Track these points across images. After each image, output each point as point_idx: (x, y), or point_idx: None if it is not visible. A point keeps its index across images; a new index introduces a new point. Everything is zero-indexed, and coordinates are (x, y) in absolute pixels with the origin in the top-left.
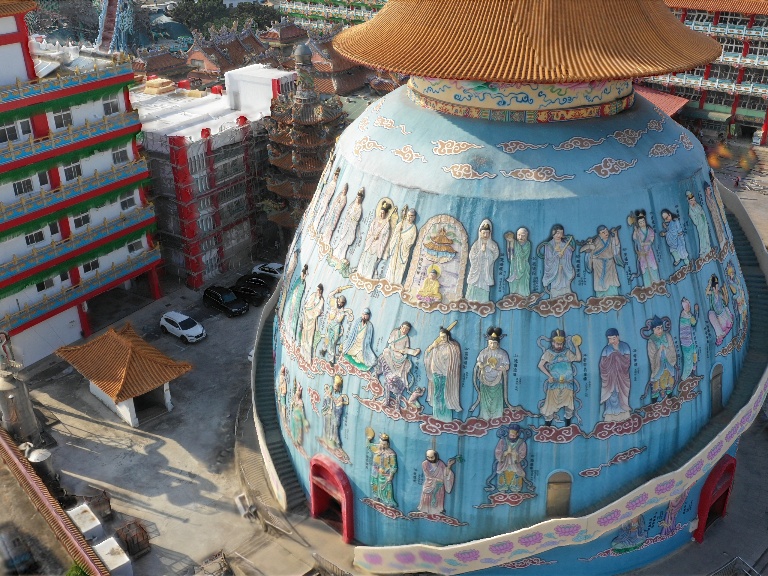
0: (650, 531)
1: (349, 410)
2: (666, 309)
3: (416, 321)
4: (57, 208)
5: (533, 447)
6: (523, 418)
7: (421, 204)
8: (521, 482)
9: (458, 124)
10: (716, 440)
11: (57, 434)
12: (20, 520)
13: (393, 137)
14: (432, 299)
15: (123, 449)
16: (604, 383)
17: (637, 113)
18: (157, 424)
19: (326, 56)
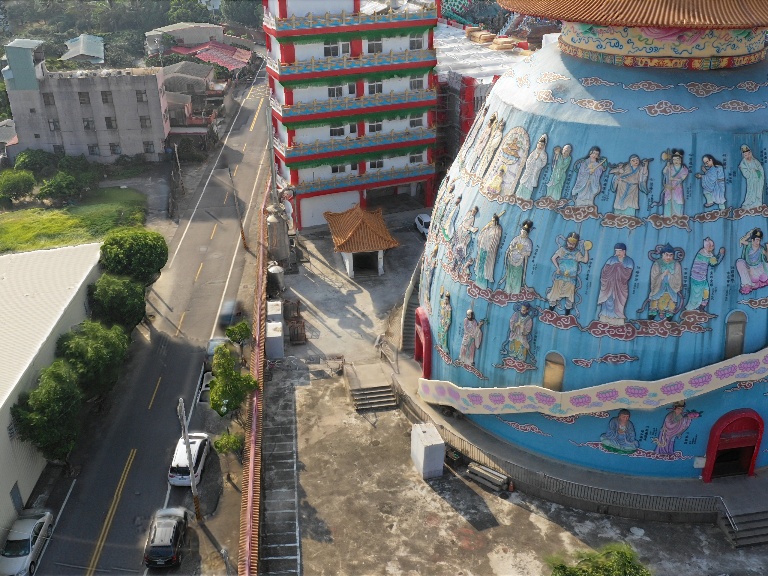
0: (642, 443)
1: (436, 271)
2: (682, 241)
3: (482, 207)
4: (355, 112)
5: (538, 325)
6: (534, 299)
7: (510, 117)
8: (526, 353)
9: (565, 61)
10: (701, 370)
11: (303, 268)
12: (248, 304)
13: (524, 68)
14: (495, 191)
15: (334, 287)
16: (603, 287)
17: (734, 72)
18: (366, 280)
19: None
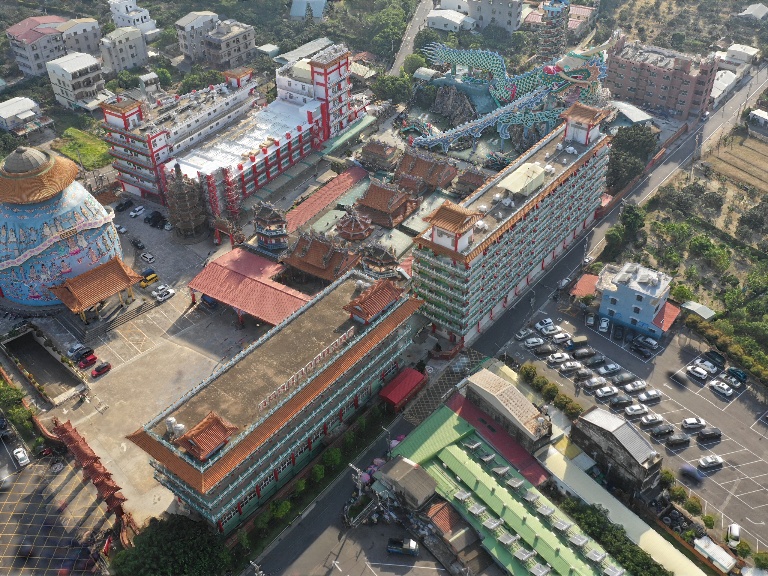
0: None
1: None
2: None
3: None
4: None
5: None
6: None
7: None
8: None
9: None
10: None
11: None
12: None
13: None
14: None
15: None
16: None
17: None
18: None
19: (365, 193)
